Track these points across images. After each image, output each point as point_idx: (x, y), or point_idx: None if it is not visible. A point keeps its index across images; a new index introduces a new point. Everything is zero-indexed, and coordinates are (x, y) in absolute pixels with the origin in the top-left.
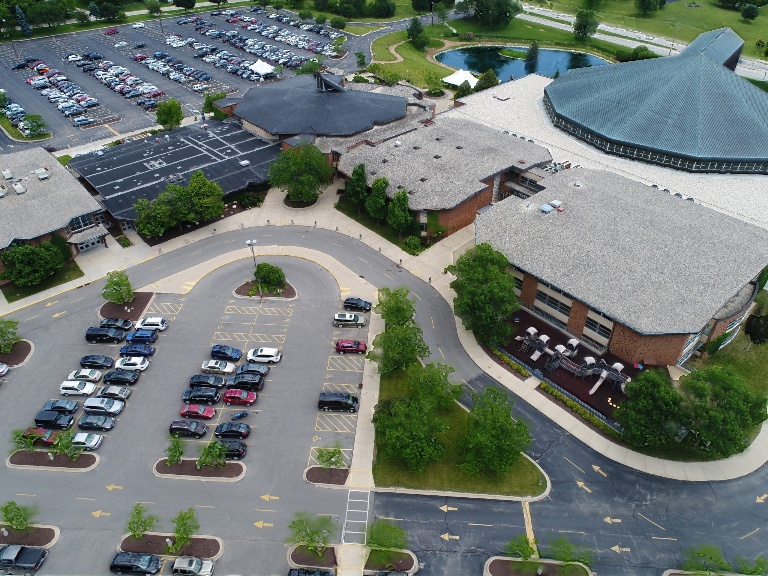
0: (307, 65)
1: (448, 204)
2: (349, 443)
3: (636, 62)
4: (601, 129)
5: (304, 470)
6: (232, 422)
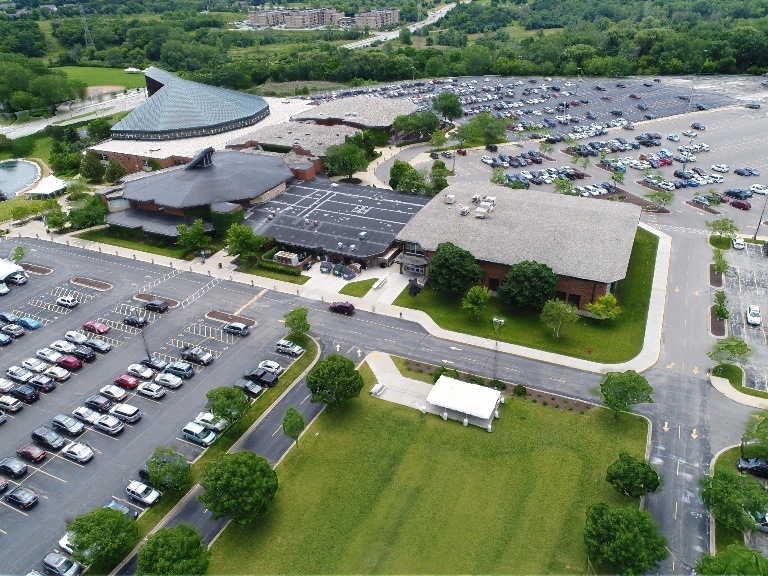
0: (89, 201)
1: (359, 130)
2: (504, 146)
3: (154, 98)
4: (242, 116)
5: (522, 148)
6: (524, 155)
